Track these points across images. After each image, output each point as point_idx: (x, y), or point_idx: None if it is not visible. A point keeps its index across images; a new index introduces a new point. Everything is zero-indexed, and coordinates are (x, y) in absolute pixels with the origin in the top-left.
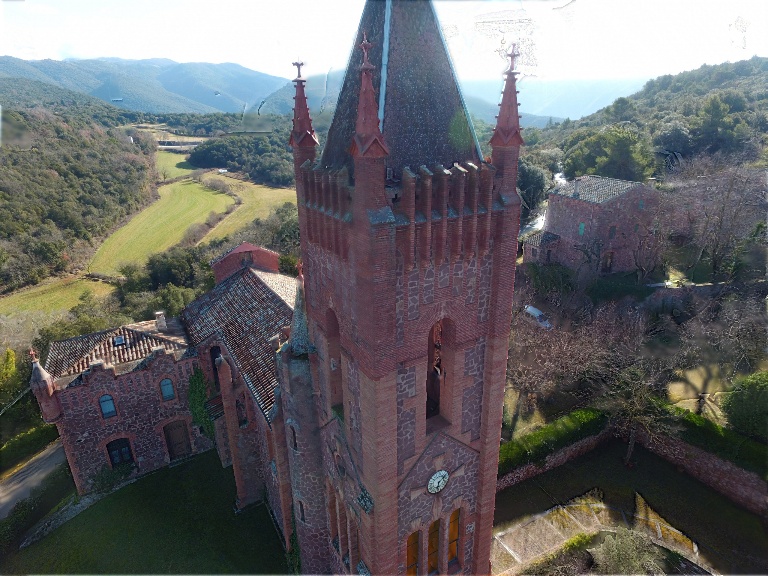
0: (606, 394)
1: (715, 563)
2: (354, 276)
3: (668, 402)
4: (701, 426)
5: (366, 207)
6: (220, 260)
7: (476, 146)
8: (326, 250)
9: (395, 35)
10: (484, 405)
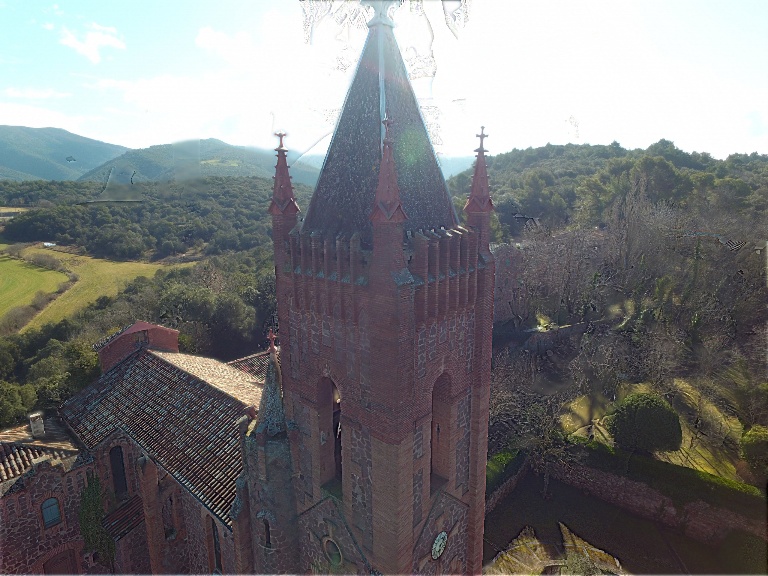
0: (516, 434)
1: (635, 573)
2: (367, 339)
3: (570, 432)
4: (596, 449)
5: (390, 269)
6: (109, 343)
7: (454, 212)
8: (322, 316)
9: (390, 114)
10: (472, 456)
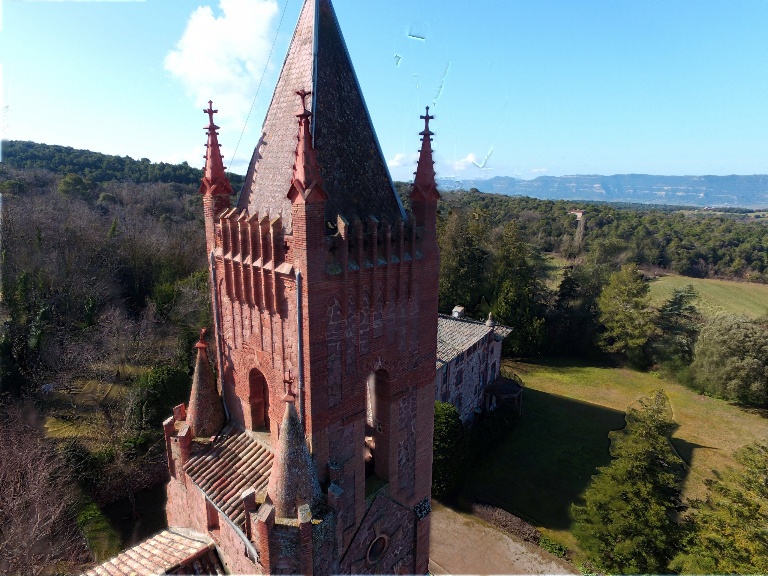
0: None
1: None
2: (417, 306)
3: None
4: (145, 441)
5: None
6: None
7: None
8: (374, 308)
9: None
10: None
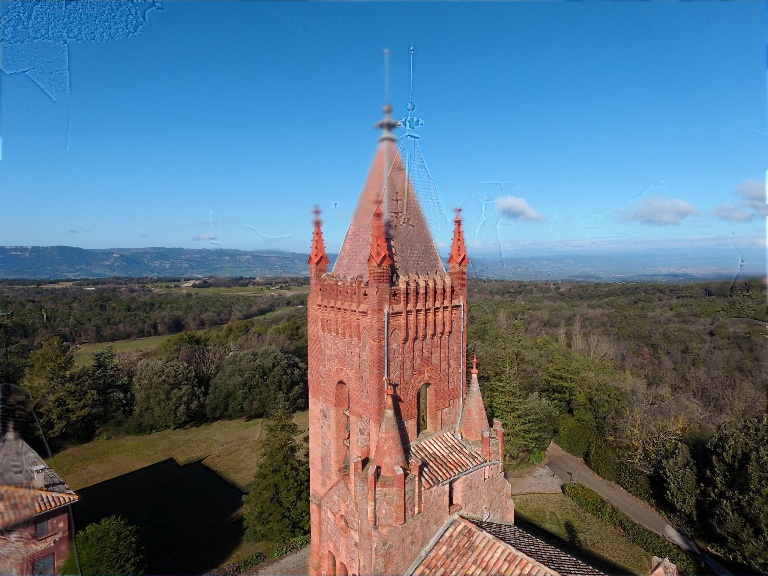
0: None
1: None
2: None
3: None
4: None
5: None
6: None
7: (337, 264)
8: None
9: None
10: None
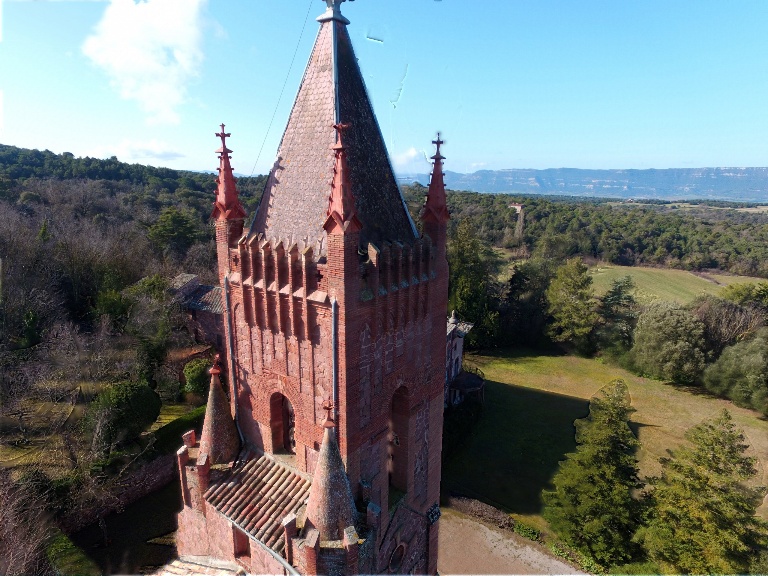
0: None
1: None
2: (430, 322)
3: None
4: (111, 462)
5: None
6: None
7: None
8: None
9: None
10: None
